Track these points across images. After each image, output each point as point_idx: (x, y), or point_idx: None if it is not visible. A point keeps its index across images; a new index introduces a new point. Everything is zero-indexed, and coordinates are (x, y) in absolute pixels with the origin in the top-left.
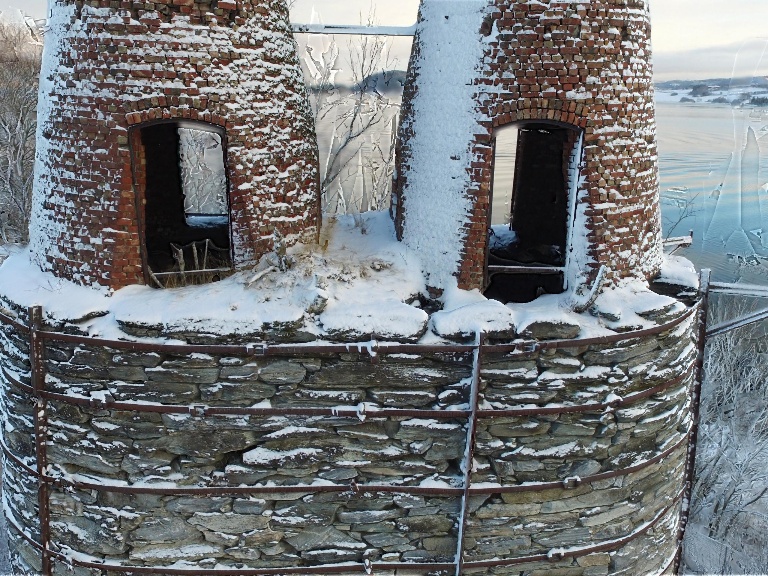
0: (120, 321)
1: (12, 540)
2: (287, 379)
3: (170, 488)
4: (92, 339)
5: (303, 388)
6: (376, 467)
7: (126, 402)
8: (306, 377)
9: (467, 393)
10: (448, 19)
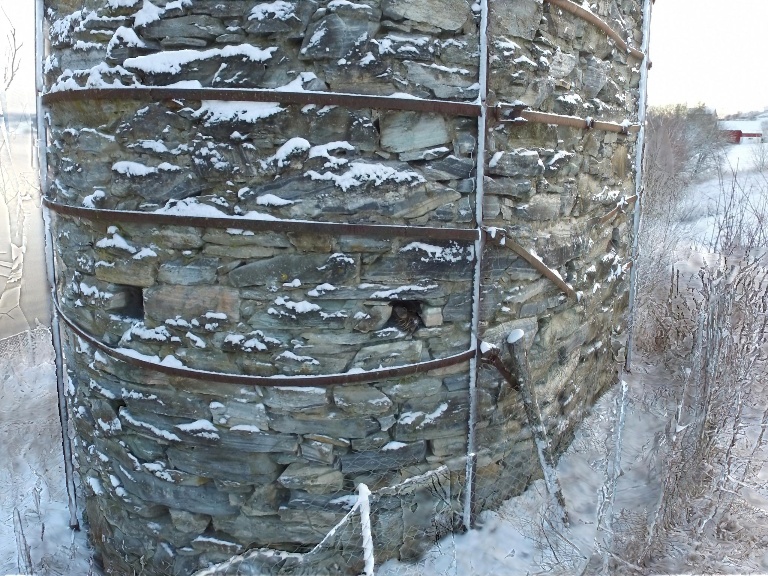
0: None
1: (366, 9)
2: None
3: None
4: None
5: None
6: None
7: None
8: None
9: None
10: None
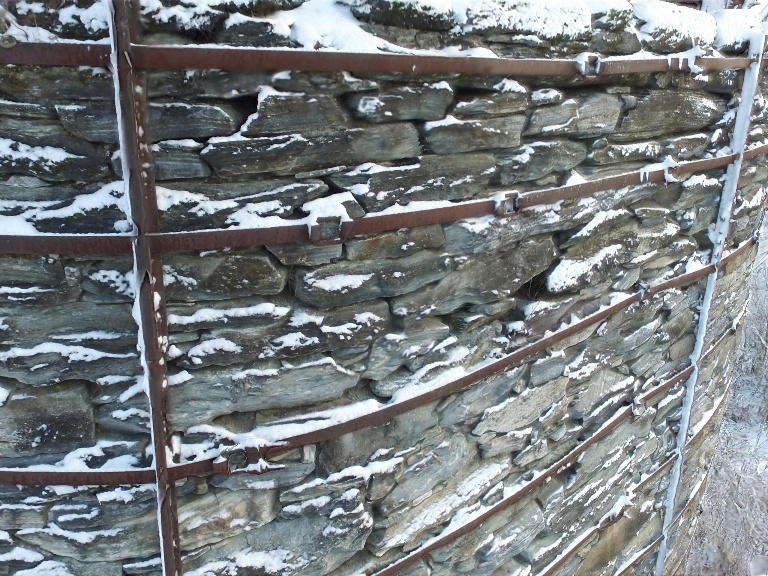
0: (380, 1)
1: None
2: (605, 126)
3: (459, 378)
4: (317, 53)
5: (611, 143)
6: (657, 258)
7: (389, 211)
8: (618, 122)
9: (727, 132)
10: None
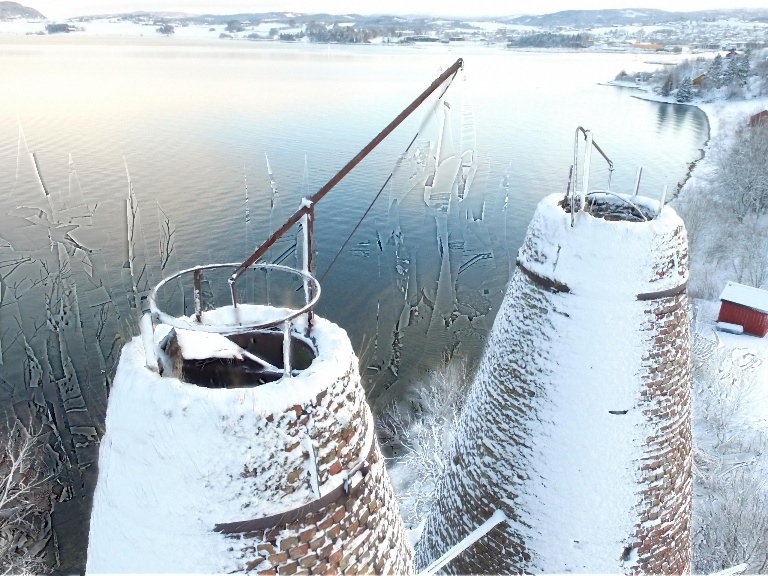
0: None
1: None
2: None
3: None
4: None
5: None
6: None
7: None
8: None
9: None
10: (579, 544)
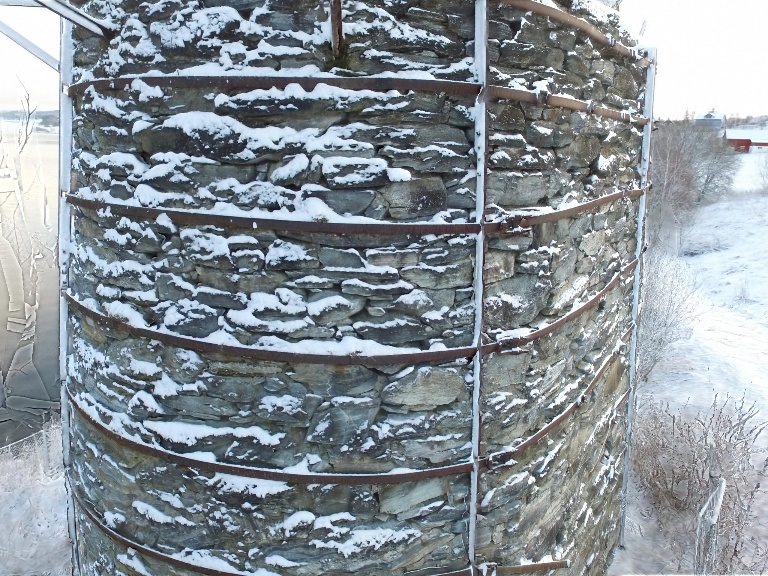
0: None
1: (367, 403)
2: None
3: (578, 205)
4: (542, 4)
5: None
6: None
7: None
8: (613, 80)
9: None
10: None
